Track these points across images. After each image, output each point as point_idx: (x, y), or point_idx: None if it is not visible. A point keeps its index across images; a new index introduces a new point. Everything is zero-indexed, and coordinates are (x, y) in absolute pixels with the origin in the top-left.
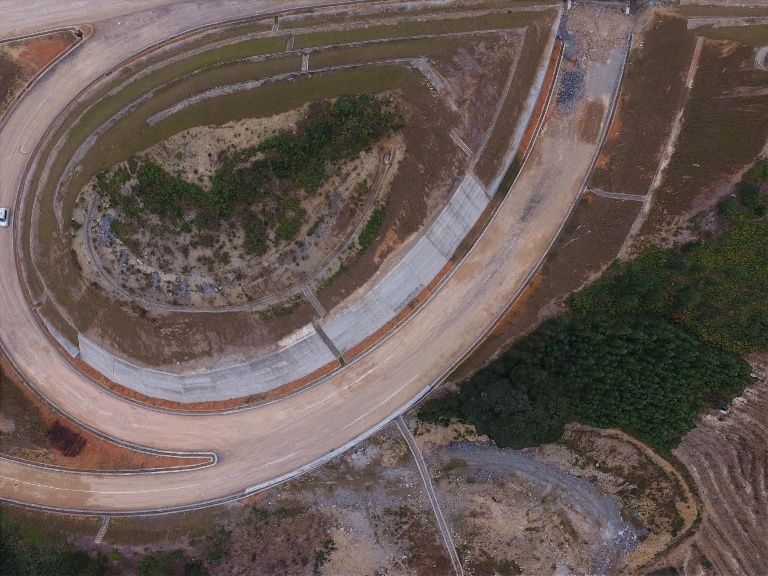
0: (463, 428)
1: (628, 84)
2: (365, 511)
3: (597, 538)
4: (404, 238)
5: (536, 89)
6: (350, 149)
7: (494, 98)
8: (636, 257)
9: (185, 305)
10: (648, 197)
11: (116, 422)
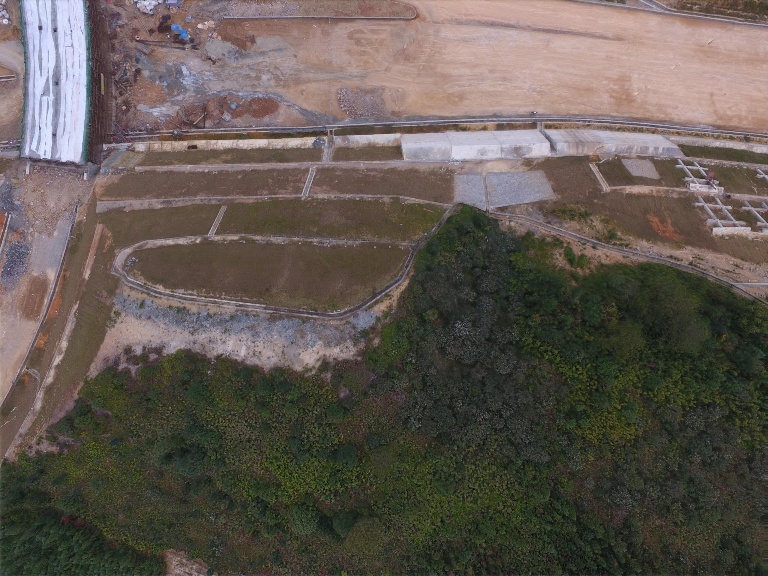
0: None
1: (69, 259)
2: None
3: None
4: None
5: None
6: None
7: None
8: (18, 459)
9: None
10: (40, 394)
11: None
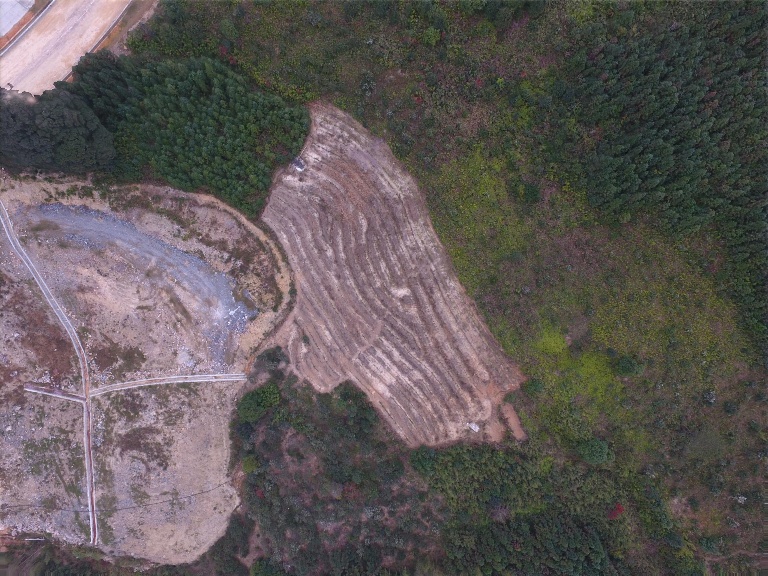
0: (52, 188)
1: None
2: None
3: (207, 317)
4: None
5: None
6: None
7: None
8: None
9: None
10: None
11: None
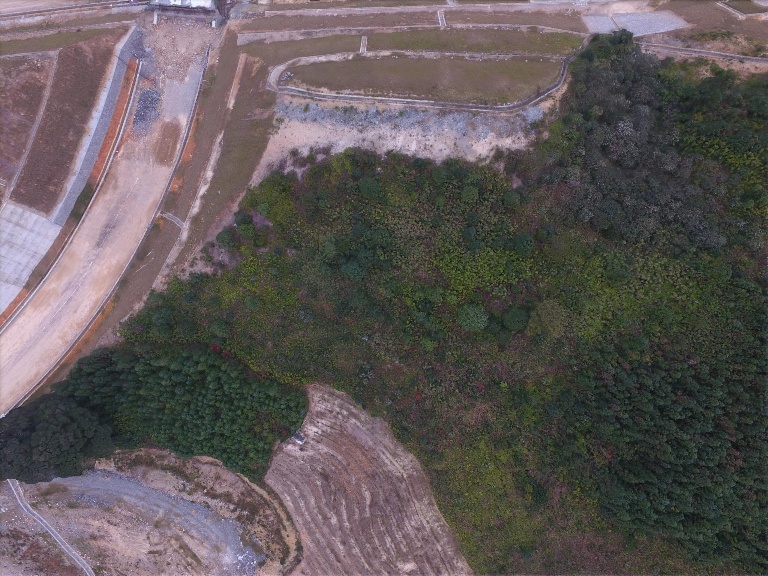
0: None
1: (203, 103)
2: None
3: (217, 563)
4: None
5: (98, 111)
6: None
7: (23, 125)
8: (167, 287)
9: None
10: (186, 224)
11: None
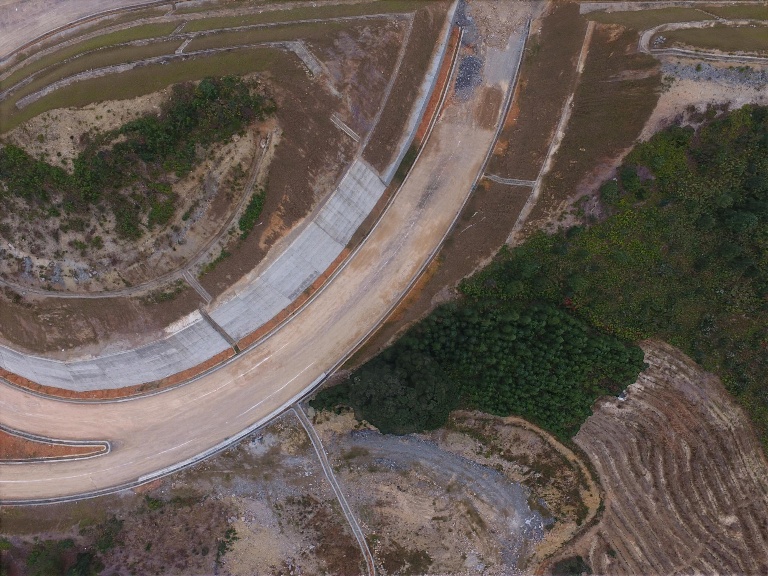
0: None
1: (526, 70)
2: (266, 500)
3: (504, 527)
4: (291, 224)
5: (431, 75)
6: (220, 132)
7: (381, 83)
8: (524, 242)
9: (60, 290)
10: (538, 182)
11: (9, 411)
